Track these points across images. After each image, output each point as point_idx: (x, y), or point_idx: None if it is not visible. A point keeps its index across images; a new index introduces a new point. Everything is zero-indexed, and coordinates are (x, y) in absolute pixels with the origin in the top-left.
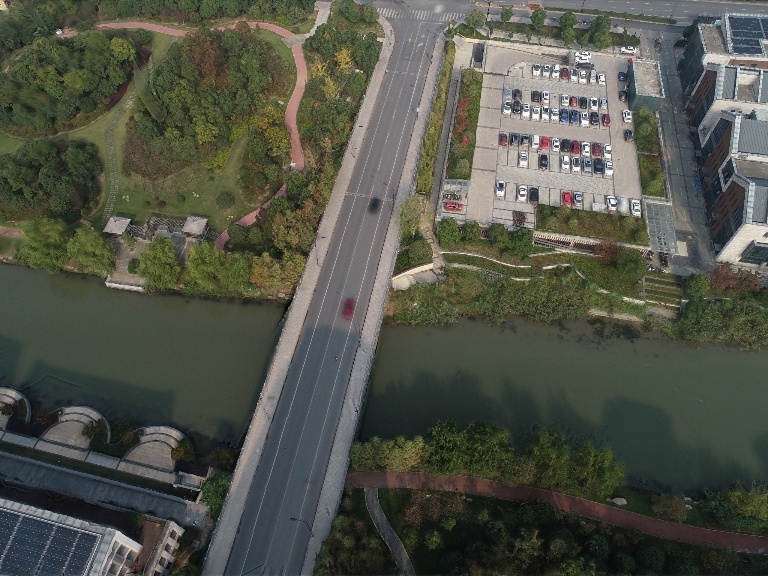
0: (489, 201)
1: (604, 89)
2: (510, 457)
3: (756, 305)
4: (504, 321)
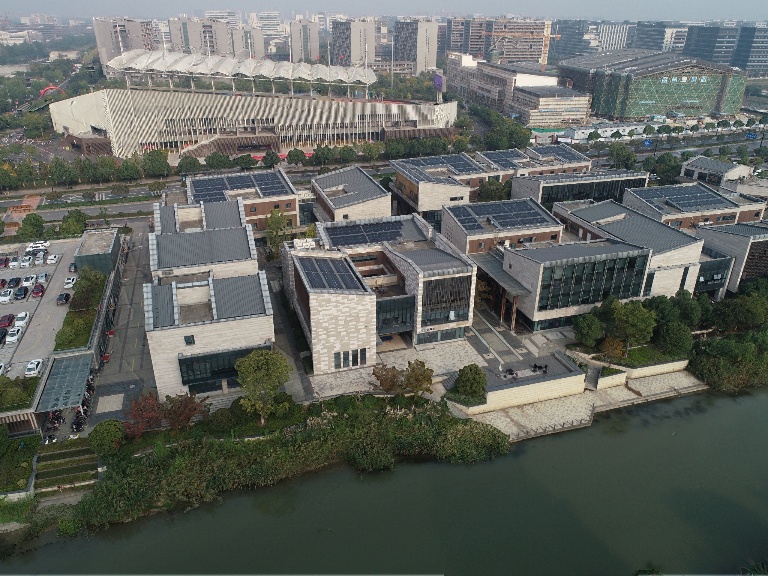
0: None
1: (53, 267)
2: None
3: (204, 438)
4: None
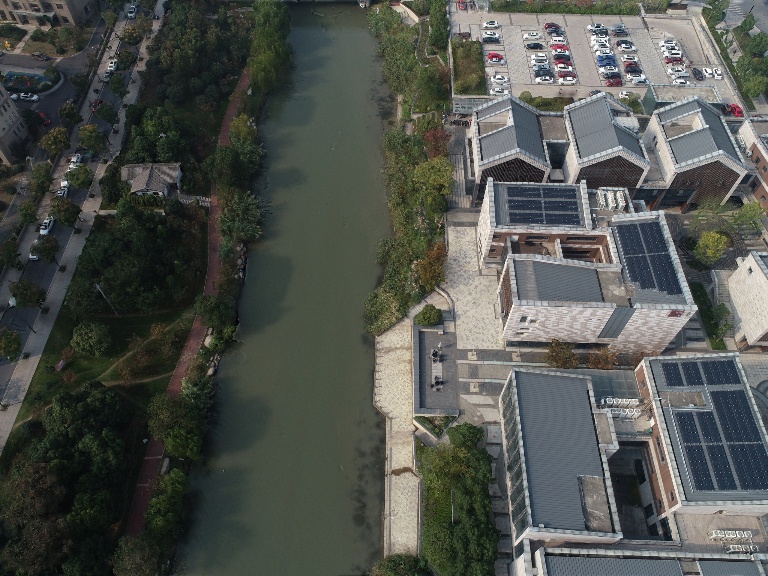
0: (476, 22)
1: None
2: (260, 18)
3: None
4: (379, 52)
